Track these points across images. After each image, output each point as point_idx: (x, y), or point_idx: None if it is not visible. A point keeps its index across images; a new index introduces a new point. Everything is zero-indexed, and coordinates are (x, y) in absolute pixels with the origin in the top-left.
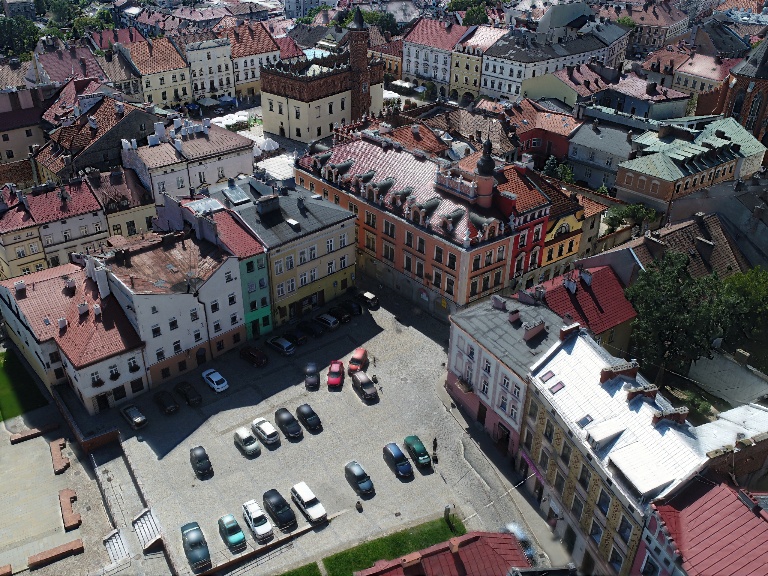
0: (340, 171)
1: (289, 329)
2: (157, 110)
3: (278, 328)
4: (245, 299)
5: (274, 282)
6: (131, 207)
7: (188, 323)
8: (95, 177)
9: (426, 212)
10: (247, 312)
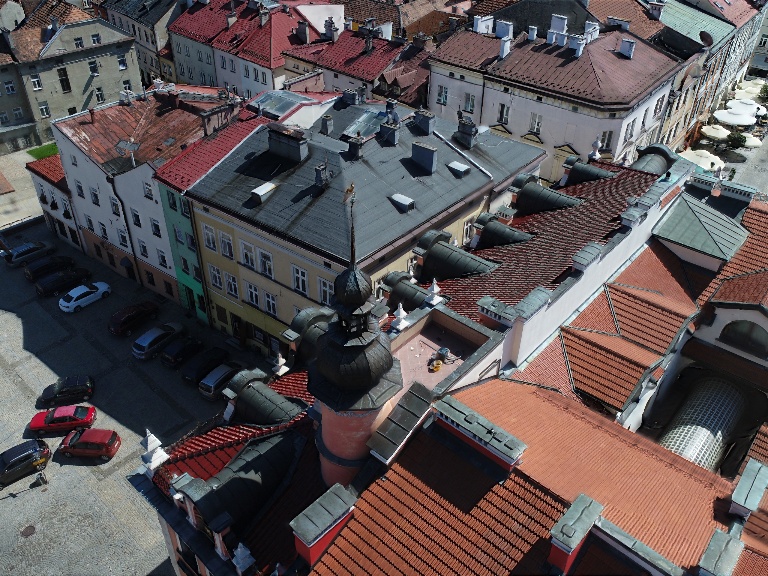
0: (529, 201)
1: (211, 342)
2: (704, 30)
3: (217, 330)
4: (174, 244)
5: (205, 255)
6: (399, 99)
7: (110, 211)
8: (419, 47)
9: (308, 349)
10: (179, 266)
